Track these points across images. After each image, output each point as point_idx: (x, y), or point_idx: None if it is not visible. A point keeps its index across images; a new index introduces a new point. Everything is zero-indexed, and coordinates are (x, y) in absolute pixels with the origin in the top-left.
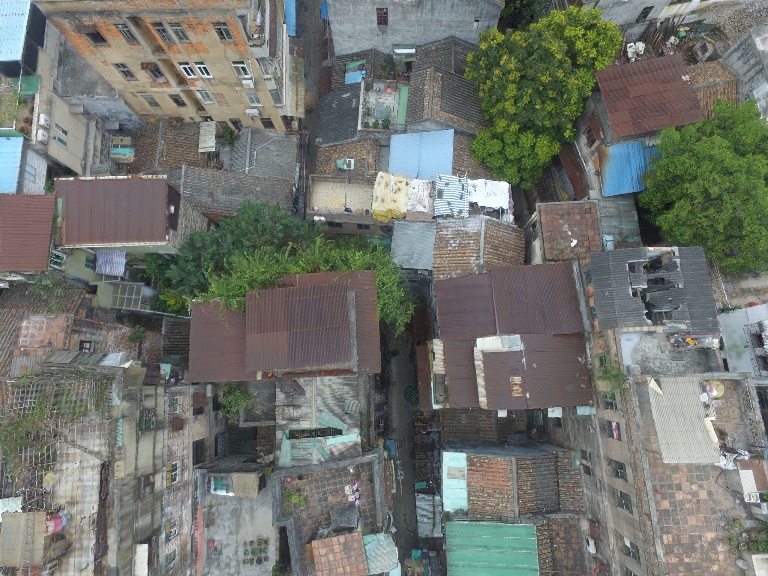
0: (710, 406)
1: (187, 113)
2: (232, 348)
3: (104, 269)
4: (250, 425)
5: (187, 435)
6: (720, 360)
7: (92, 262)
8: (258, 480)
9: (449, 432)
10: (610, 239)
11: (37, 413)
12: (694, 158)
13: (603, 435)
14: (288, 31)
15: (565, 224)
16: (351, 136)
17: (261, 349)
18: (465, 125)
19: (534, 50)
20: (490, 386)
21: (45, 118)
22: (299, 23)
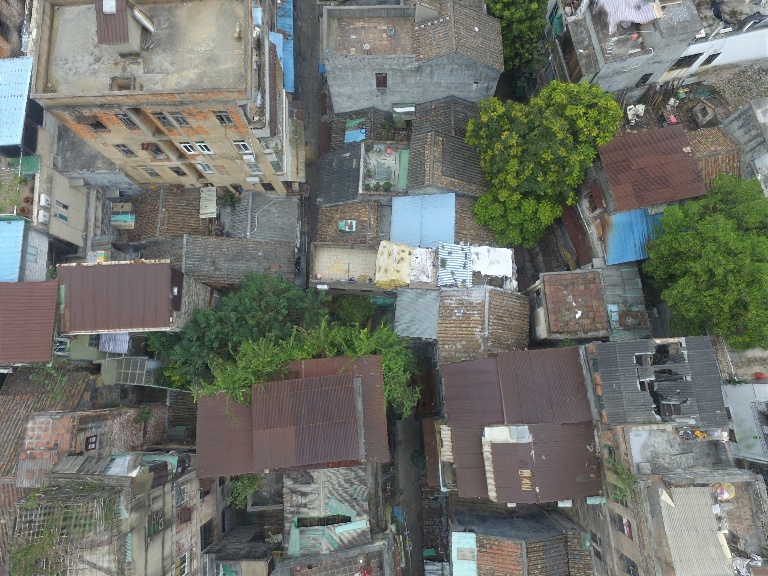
0: (722, 518)
1: (188, 181)
2: (239, 441)
3: (108, 347)
4: (258, 509)
5: (195, 522)
6: (730, 454)
7: (95, 339)
8: (267, 568)
9: (457, 501)
10: (615, 309)
11: (46, 538)
12: (698, 237)
13: (614, 527)
14: (287, 88)
15: (569, 295)
16: (352, 198)
17: (268, 446)
18: (466, 188)
19: (535, 127)
20: (499, 478)
21: (46, 198)
22: (297, 74)
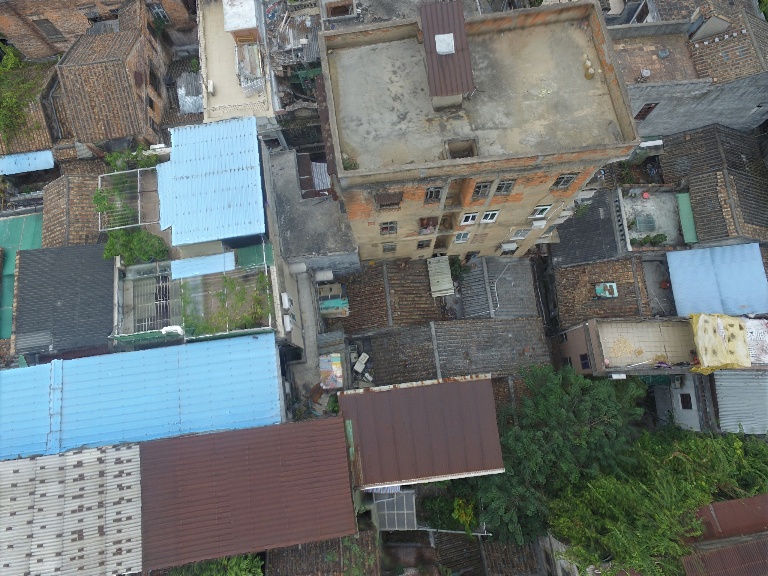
0: None
1: (421, 253)
2: None
3: None
4: None
5: None
6: None
7: None
8: None
9: None
10: None
11: None
12: None
13: None
14: None
15: None
16: (609, 255)
17: None
18: (767, 235)
19: None
20: None
21: (287, 298)
22: None
